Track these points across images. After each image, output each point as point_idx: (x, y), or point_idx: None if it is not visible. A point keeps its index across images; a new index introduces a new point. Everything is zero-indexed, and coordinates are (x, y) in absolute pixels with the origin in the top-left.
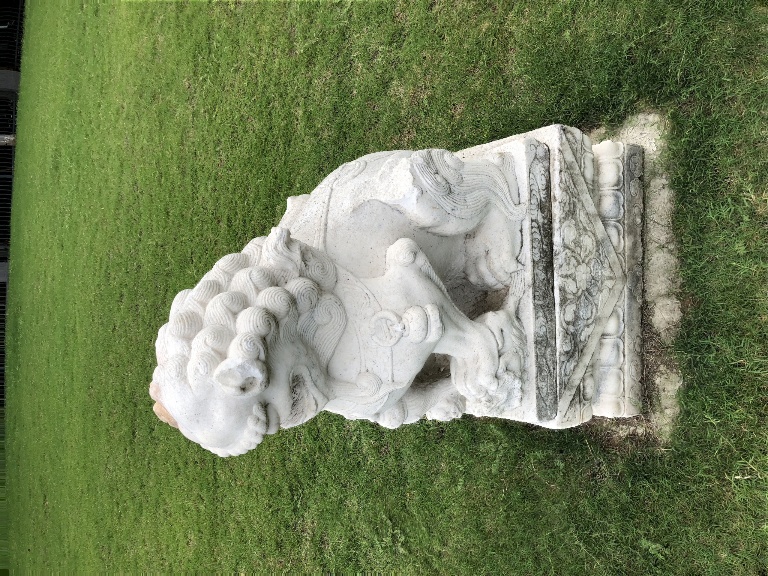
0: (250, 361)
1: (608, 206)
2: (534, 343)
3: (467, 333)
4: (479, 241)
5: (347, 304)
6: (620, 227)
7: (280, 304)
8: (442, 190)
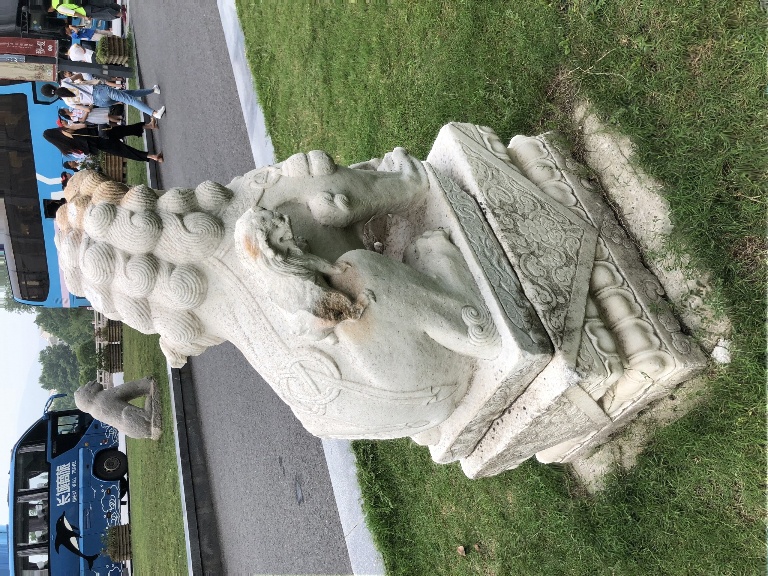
0: None
1: None
2: None
3: None
4: None
5: None
6: None
7: None
8: None
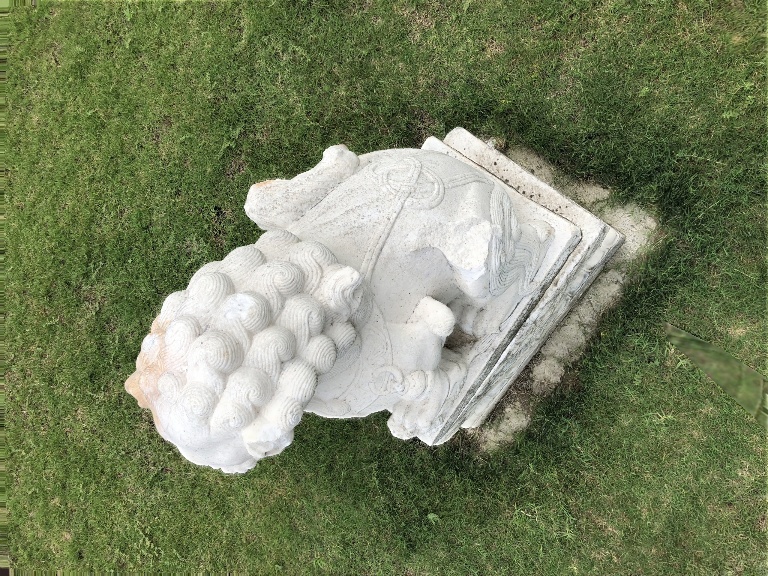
0: (287, 434)
1: (575, 284)
2: (467, 392)
3: None
4: None
5: (365, 346)
6: (569, 300)
7: (328, 366)
8: (500, 271)
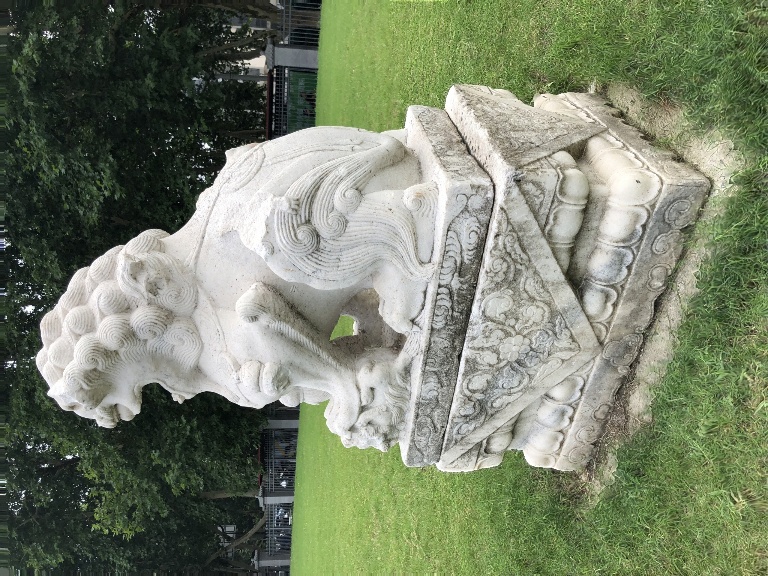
0: (70, 393)
1: (597, 266)
2: (415, 404)
3: (331, 382)
4: (375, 287)
5: (202, 332)
6: (613, 292)
7: (110, 341)
8: (301, 250)
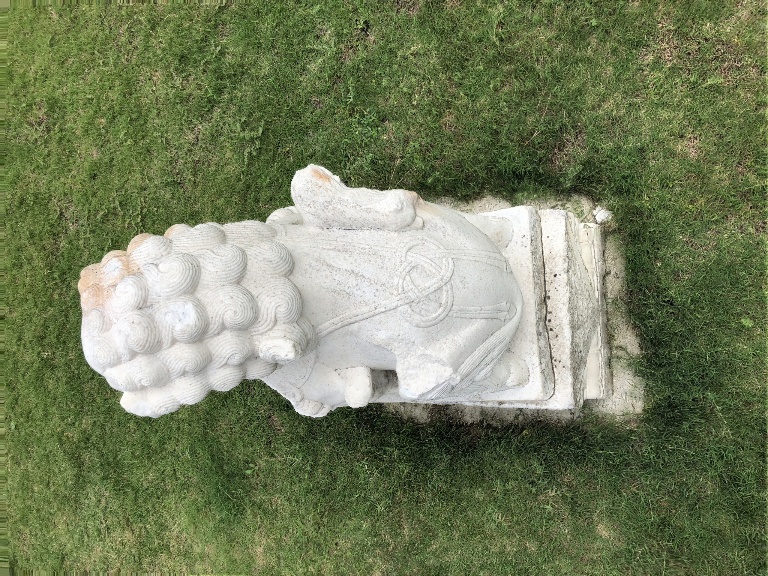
0: None
1: None
2: None
3: None
4: None
5: (286, 367)
6: None
7: None
8: None
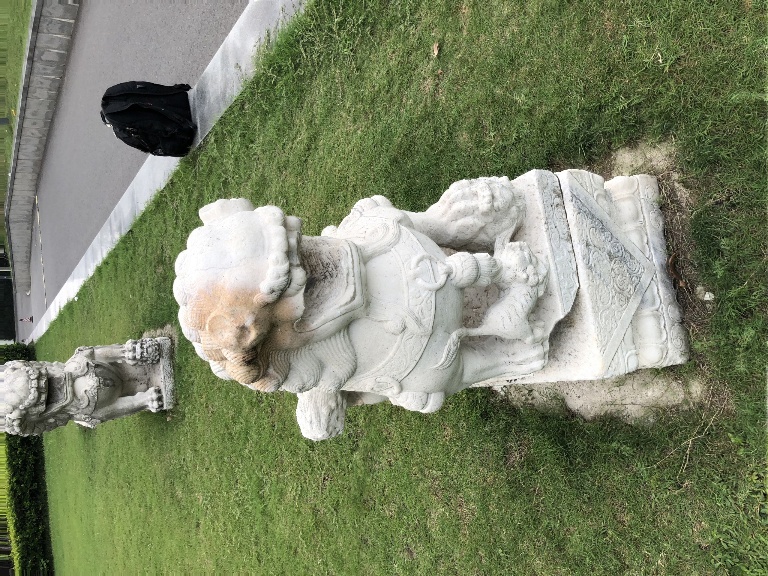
0: None
1: None
2: None
3: None
4: None
5: None
6: None
7: None
8: None
